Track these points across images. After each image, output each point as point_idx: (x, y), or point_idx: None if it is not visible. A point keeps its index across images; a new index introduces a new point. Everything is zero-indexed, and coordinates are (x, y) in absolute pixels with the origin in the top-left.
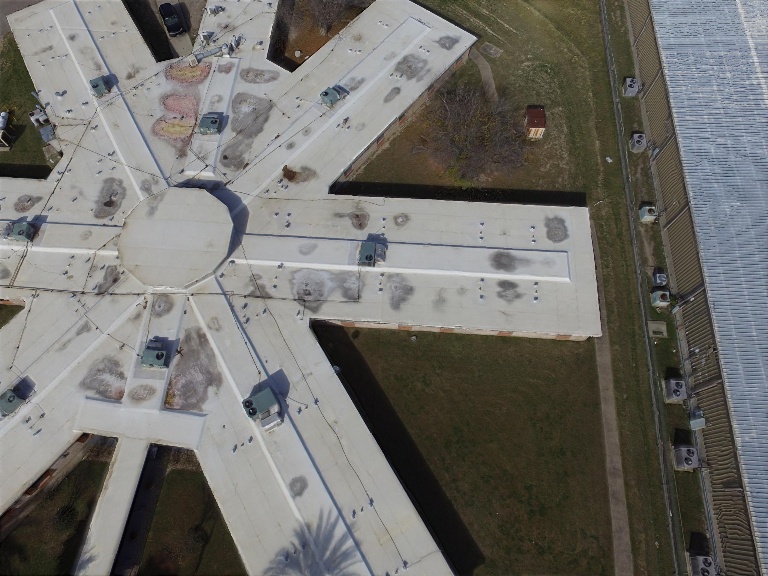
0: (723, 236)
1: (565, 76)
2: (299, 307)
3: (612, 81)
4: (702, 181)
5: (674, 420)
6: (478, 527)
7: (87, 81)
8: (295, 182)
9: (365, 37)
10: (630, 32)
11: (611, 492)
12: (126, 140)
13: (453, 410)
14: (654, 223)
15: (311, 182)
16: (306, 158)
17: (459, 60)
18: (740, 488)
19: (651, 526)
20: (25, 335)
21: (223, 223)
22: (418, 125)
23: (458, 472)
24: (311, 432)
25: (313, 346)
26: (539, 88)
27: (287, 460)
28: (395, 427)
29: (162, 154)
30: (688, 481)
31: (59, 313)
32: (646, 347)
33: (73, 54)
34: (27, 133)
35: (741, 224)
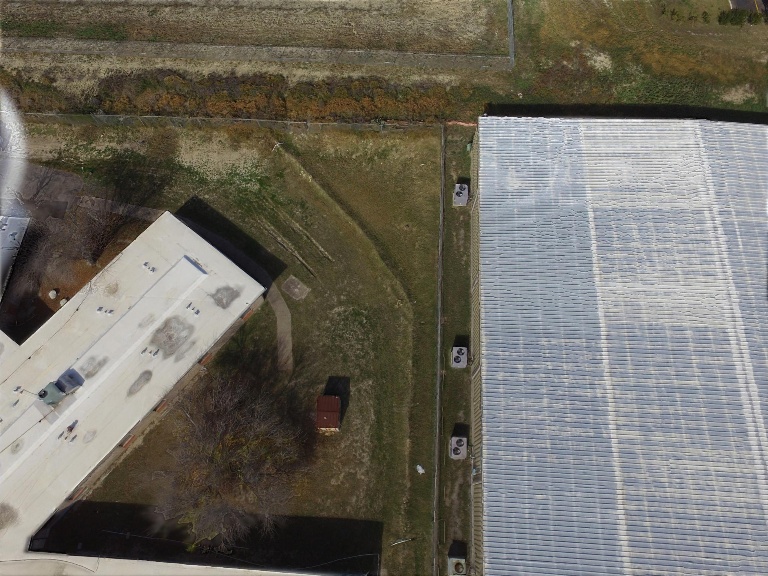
0: None
1: (383, 330)
2: None
3: None
4: (506, 568)
5: None
6: None
7: None
8: None
9: (122, 288)
10: (471, 266)
11: None
12: None
13: None
14: None
15: (9, 530)
16: (11, 488)
17: (247, 311)
18: None
19: None
20: None
21: None
22: None
23: None
24: None
25: None
26: (348, 349)
27: None
28: None
29: None
30: None
31: None
32: None
33: None
34: None
35: None
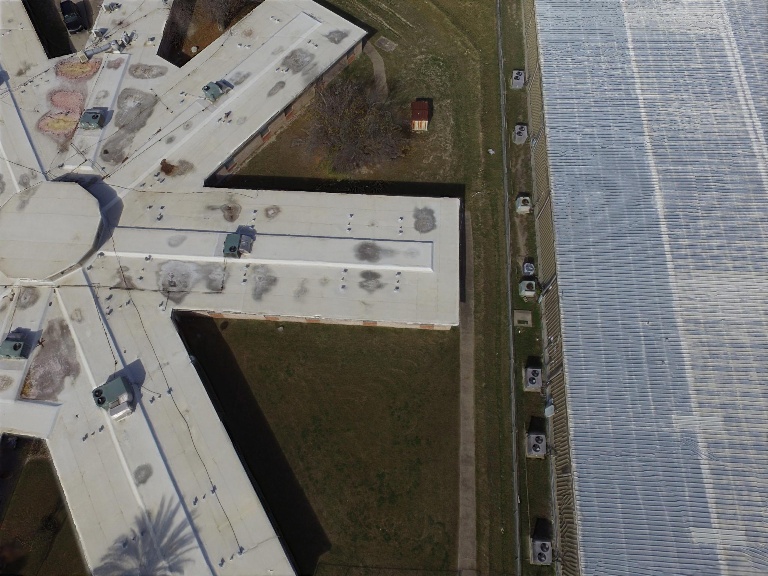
0: (579, 225)
1: (456, 69)
2: (163, 298)
3: (501, 73)
4: (565, 171)
5: (531, 408)
6: (327, 514)
7: None
8: (172, 175)
9: (256, 32)
10: (523, 25)
11: (461, 479)
12: (10, 135)
13: (313, 399)
14: (529, 213)
15: (187, 175)
16: (185, 152)
17: (351, 54)
18: (570, 473)
19: (498, 512)
20: None
21: (91, 216)
22: None
23: (312, 460)
24: (162, 421)
25: (172, 336)
26: (430, 81)
27: (134, 448)
28: (254, 416)
29: (44, 149)
30: (539, 468)
31: None
32: (509, 336)
33: None
34: None
35: (598, 213)
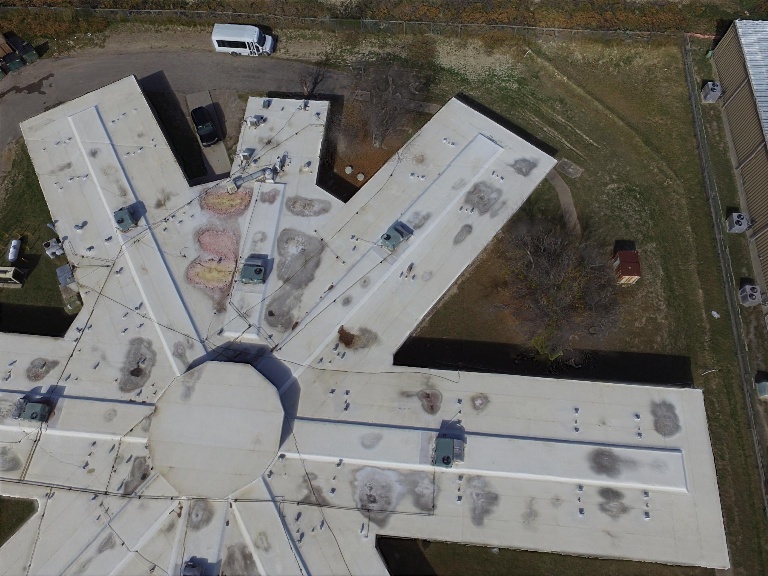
0: None
1: (657, 203)
2: (363, 520)
3: (714, 213)
4: None
5: None
6: None
7: (111, 210)
8: (353, 348)
9: (428, 158)
10: (731, 151)
11: None
12: (156, 289)
13: None
14: None
15: (372, 349)
16: (365, 316)
17: None
18: None
19: None
20: (38, 549)
21: (272, 411)
22: (490, 264)
23: None
24: None
25: (381, 575)
26: (628, 218)
27: None
28: None
29: (197, 307)
30: None
31: (78, 520)
32: None
33: (95, 175)
34: (41, 265)
35: None
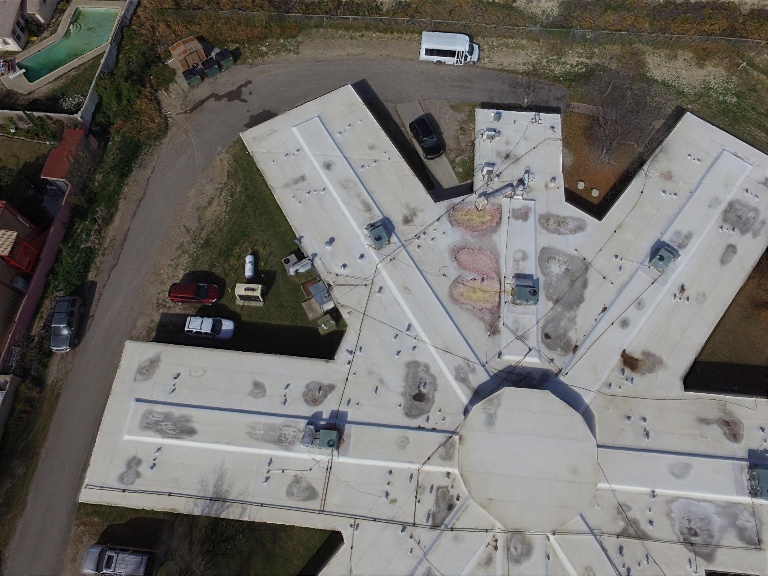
0: None
1: None
2: (689, 554)
3: None
4: None
5: None
6: None
7: (358, 226)
8: (641, 373)
9: (676, 175)
10: None
11: None
12: (423, 310)
13: None
14: None
15: (660, 374)
16: (646, 340)
17: None
18: None
19: None
20: None
21: (584, 441)
22: (745, 285)
23: None
24: None
25: None
26: None
27: None
28: None
29: (470, 329)
30: None
31: (390, 553)
32: None
33: (334, 189)
34: (279, 282)
35: None
